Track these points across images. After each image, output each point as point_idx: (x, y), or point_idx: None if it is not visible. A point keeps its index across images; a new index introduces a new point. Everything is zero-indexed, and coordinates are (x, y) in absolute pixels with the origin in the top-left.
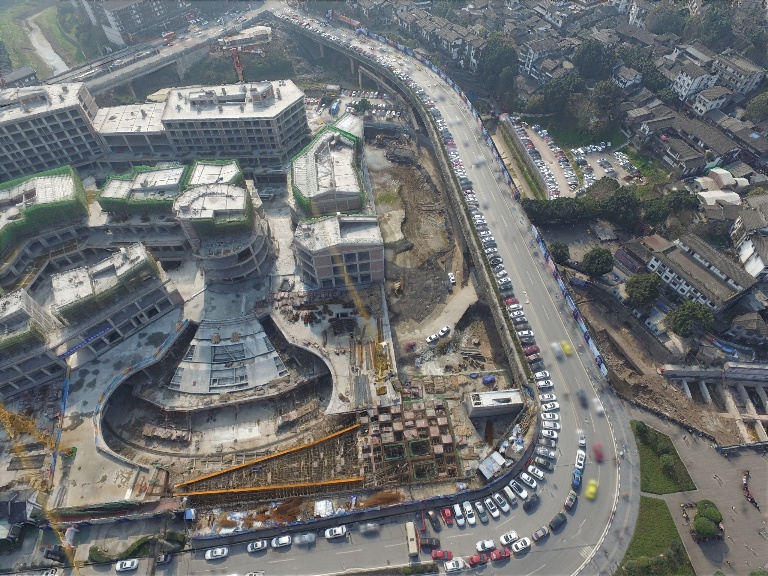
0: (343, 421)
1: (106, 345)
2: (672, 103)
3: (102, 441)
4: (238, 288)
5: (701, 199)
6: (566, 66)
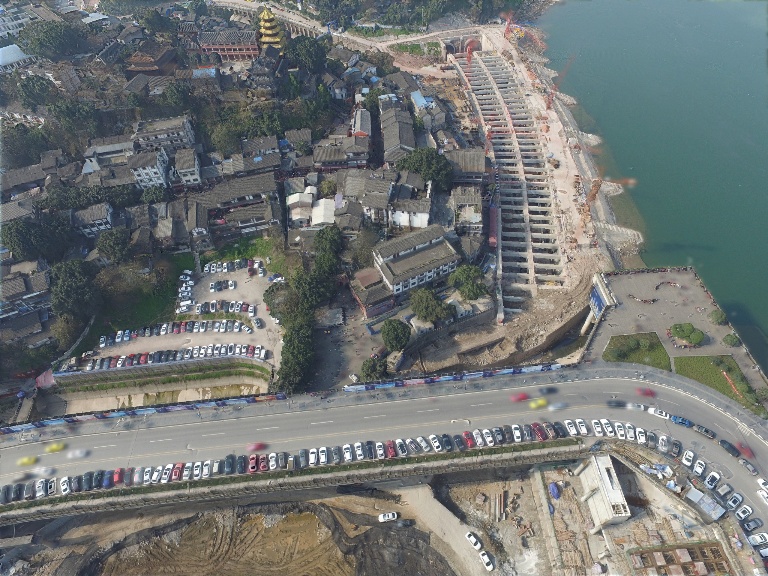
0: None
1: None
2: None
3: None
4: None
5: (322, 225)
6: (25, 270)
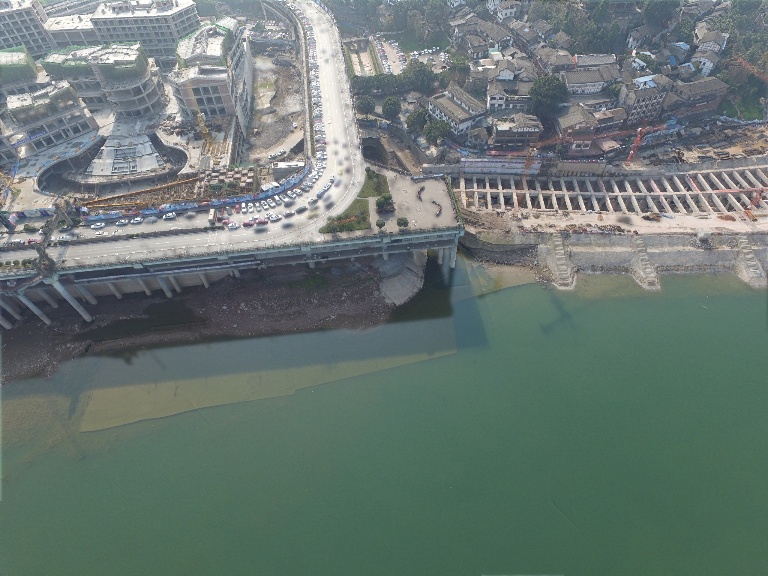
0: (190, 178)
1: (44, 147)
2: (483, 16)
3: (37, 187)
4: (136, 120)
5: None
6: None
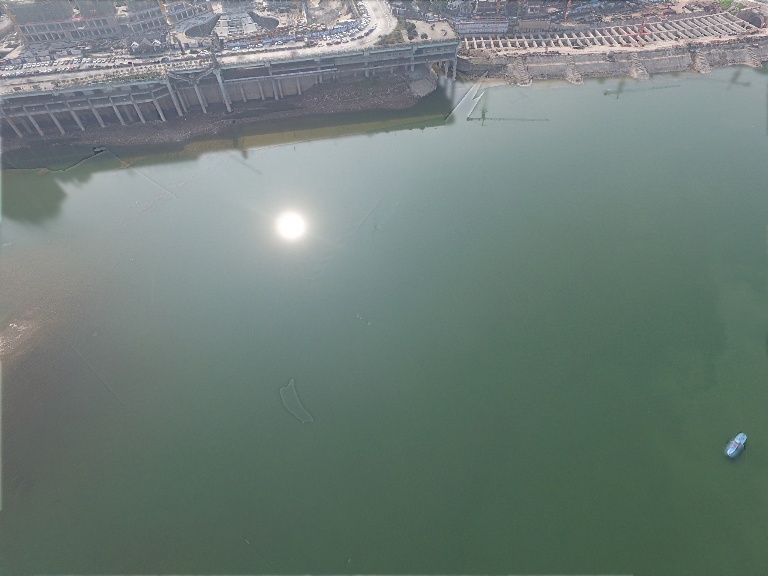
0: None
1: (182, 19)
2: None
3: None
4: (237, 5)
5: None
6: None
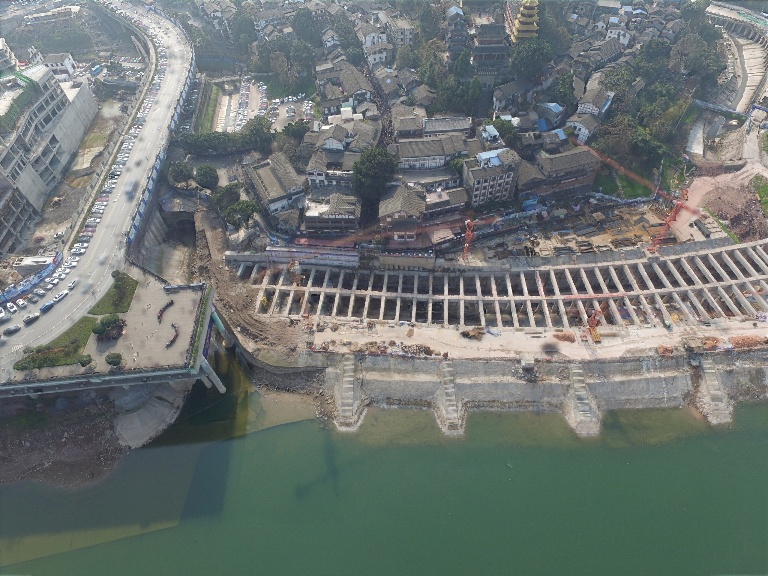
0: None
1: None
2: (355, 59)
3: None
4: None
5: None
6: (286, 31)
